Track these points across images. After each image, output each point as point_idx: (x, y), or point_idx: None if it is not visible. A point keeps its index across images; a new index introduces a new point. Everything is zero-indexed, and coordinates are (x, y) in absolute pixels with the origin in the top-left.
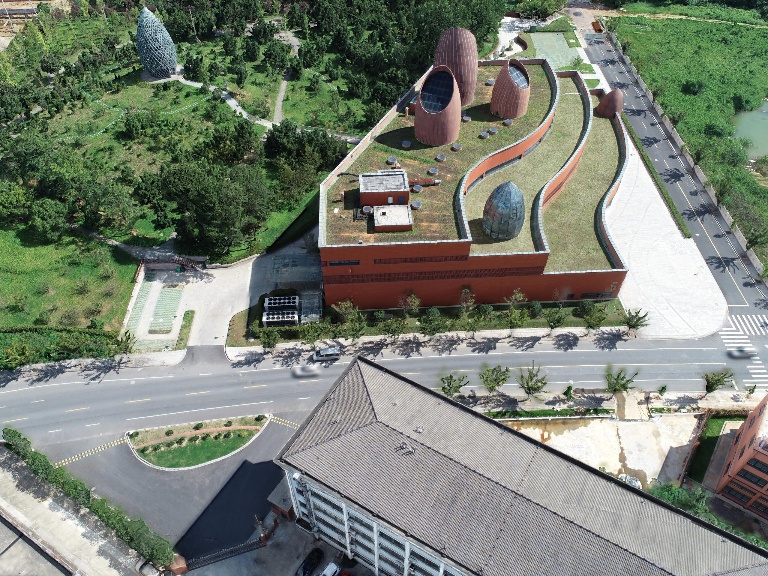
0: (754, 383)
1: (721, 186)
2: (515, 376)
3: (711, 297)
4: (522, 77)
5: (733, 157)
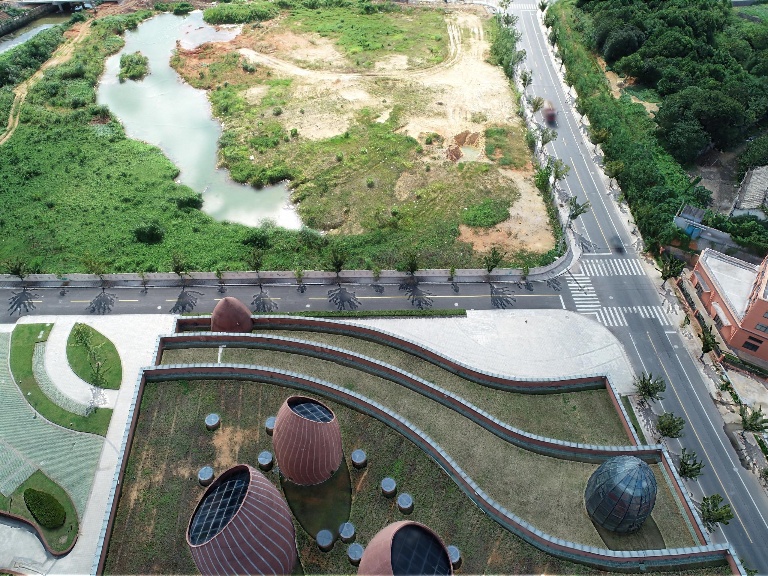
0: (662, 319)
1: (411, 260)
2: (759, 531)
3: (558, 319)
4: (303, 408)
5: (319, 238)
